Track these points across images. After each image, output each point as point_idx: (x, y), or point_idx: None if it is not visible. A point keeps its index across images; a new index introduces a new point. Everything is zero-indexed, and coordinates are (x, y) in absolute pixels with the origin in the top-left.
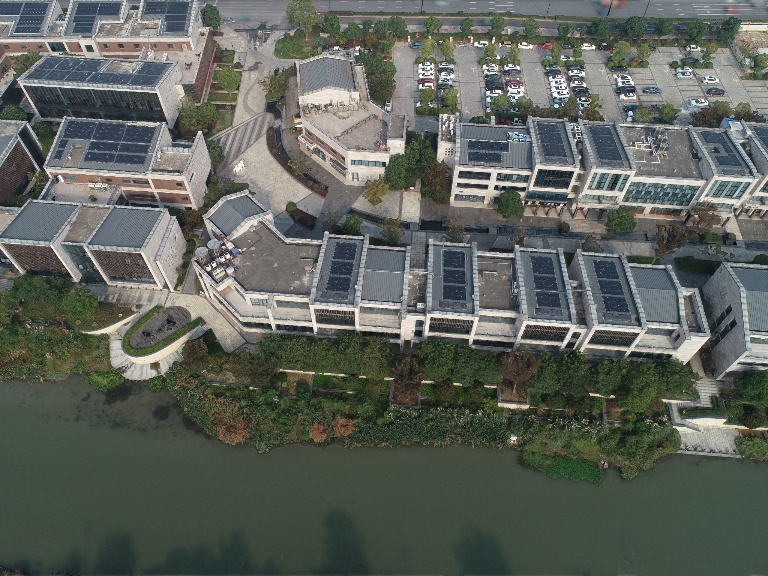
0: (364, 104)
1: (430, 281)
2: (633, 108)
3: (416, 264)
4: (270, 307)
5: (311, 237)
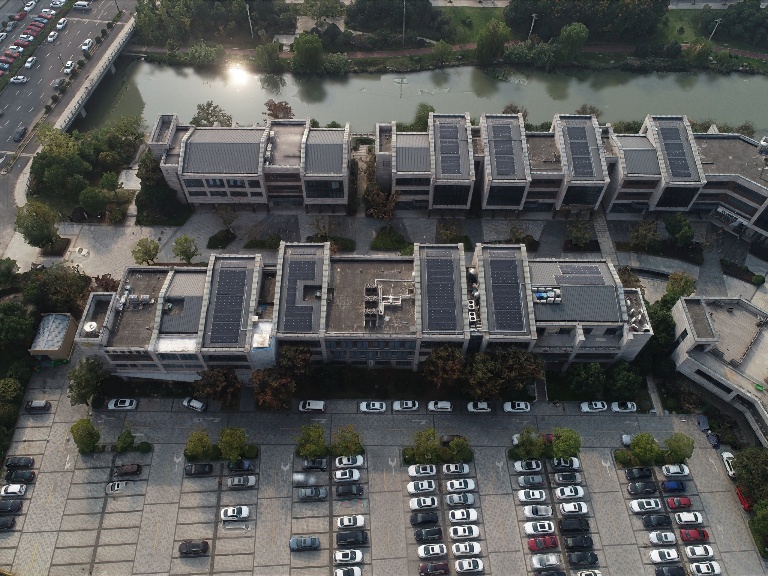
0: (764, 396)
1: (599, 138)
2: (350, 486)
3: (604, 232)
4: (713, 125)
5: (717, 253)
